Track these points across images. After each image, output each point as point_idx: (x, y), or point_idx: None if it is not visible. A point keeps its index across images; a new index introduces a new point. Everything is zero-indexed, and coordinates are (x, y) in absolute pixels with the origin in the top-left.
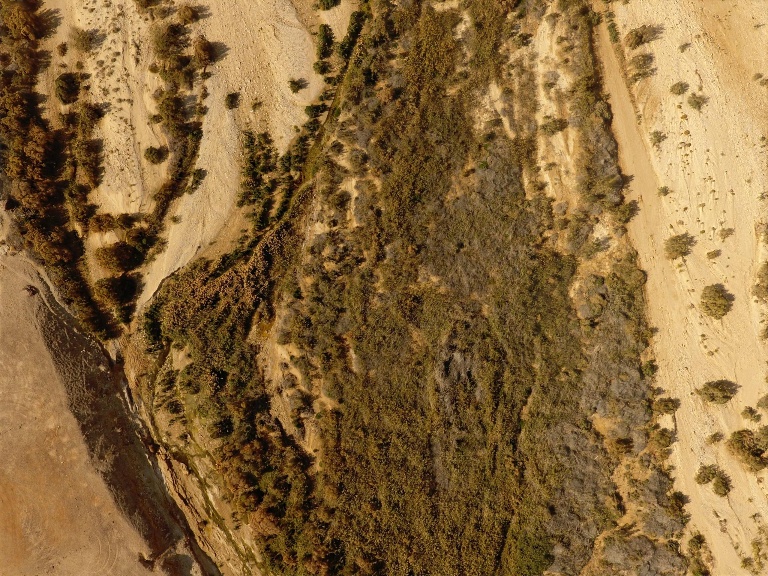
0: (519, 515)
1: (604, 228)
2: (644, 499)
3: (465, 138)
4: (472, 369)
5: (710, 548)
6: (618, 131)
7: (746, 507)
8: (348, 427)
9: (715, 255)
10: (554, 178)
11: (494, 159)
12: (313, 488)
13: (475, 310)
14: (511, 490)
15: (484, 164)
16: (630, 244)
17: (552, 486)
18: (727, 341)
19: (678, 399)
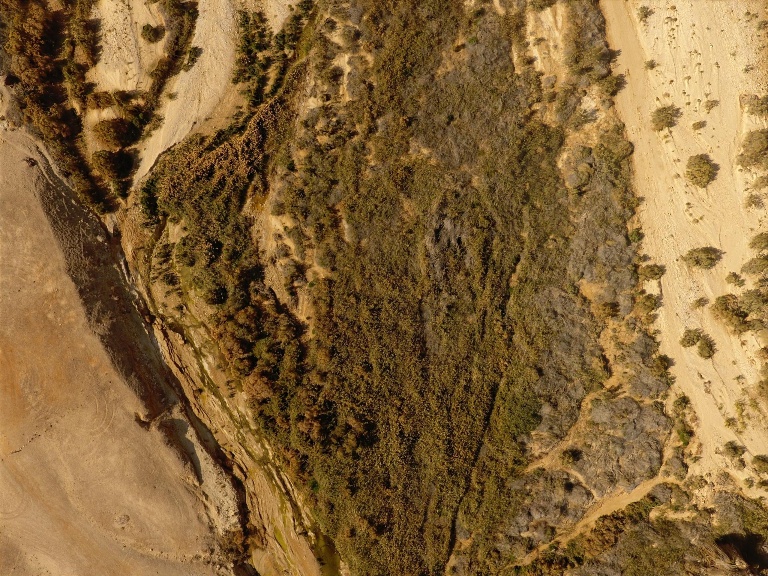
0: (507, 377)
1: (592, 100)
2: (630, 360)
3: (455, 13)
4: (462, 236)
5: (694, 409)
6: (606, 7)
7: (730, 369)
8: (340, 293)
9: (700, 125)
10: (543, 52)
11: (484, 34)
12: (306, 355)
13: (465, 181)
14: (500, 353)
15: (474, 39)
16: (617, 116)
17: (540, 348)
18: (712, 209)
19: (664, 266)
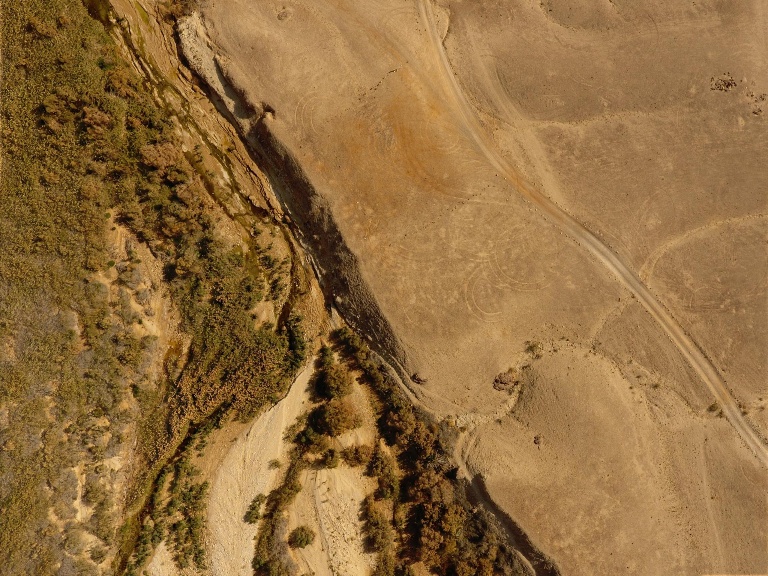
0: None
1: None
2: None
3: None
4: None
5: None
6: None
7: None
8: (76, 255)
9: None
10: None
11: None
12: None
13: None
14: None
15: None
16: None
17: None
18: None
19: None
